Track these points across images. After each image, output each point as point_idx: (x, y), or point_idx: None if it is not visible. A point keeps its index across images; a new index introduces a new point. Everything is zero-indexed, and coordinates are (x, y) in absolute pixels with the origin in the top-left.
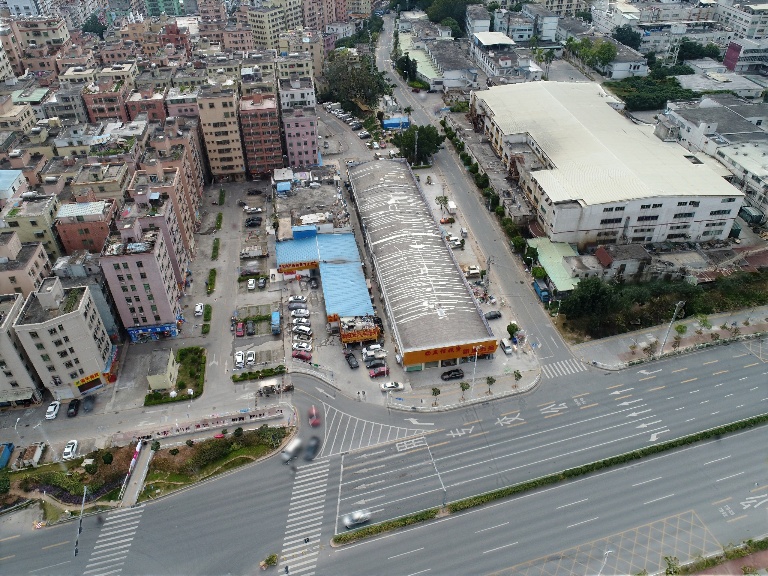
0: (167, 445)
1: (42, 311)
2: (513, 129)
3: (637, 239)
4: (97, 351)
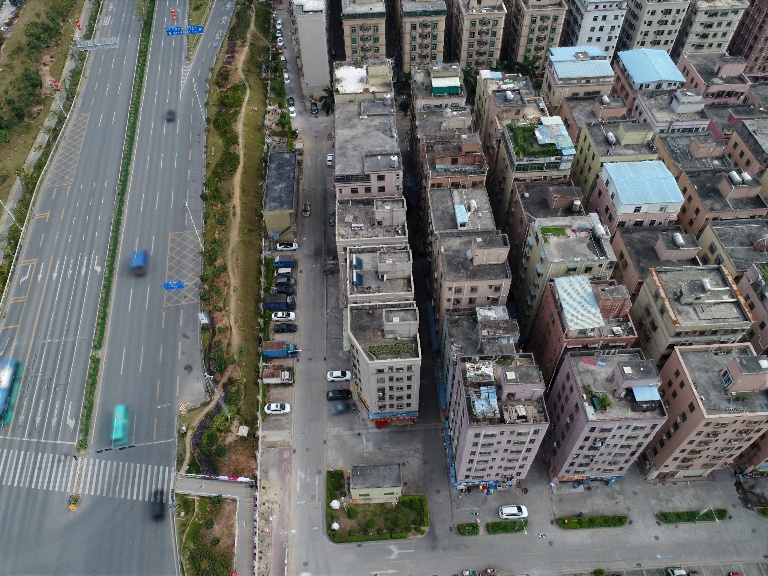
0: None
1: (382, 324)
2: None
3: None
4: (374, 398)
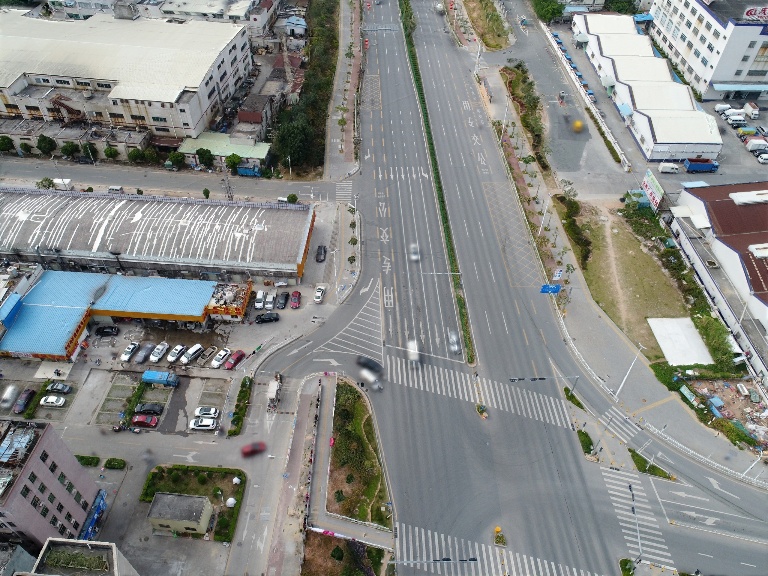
0: (326, 497)
1: None
2: (3, 78)
3: (225, 99)
4: None
